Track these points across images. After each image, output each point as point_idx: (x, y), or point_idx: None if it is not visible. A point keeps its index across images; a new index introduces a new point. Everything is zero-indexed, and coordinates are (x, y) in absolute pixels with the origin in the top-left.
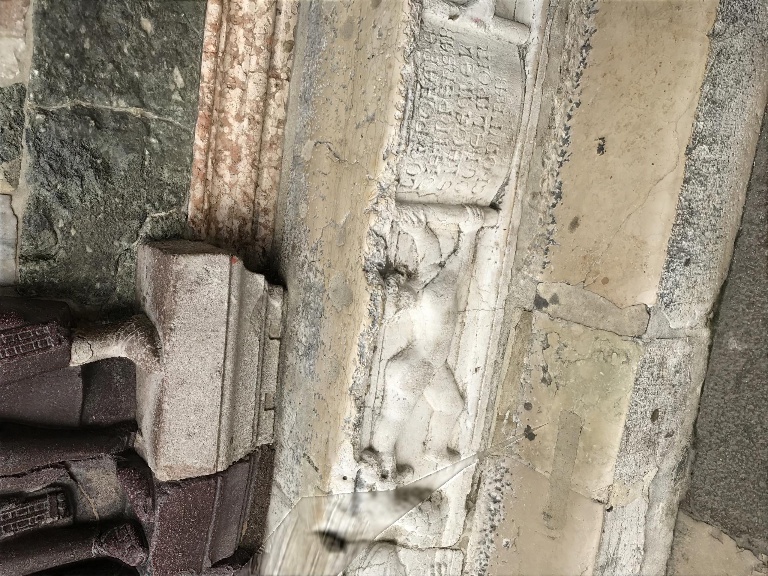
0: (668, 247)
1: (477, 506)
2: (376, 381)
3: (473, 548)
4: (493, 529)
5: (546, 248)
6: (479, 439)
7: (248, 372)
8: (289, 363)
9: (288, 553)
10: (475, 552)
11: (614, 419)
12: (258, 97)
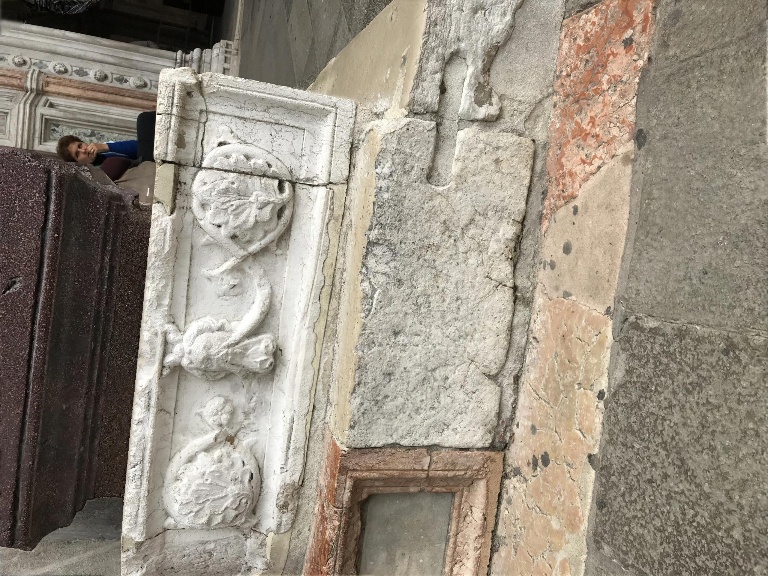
0: None
1: None
2: None
3: None
4: None
5: None
6: None
7: None
8: None
9: (80, 1)
10: None
11: None
12: None
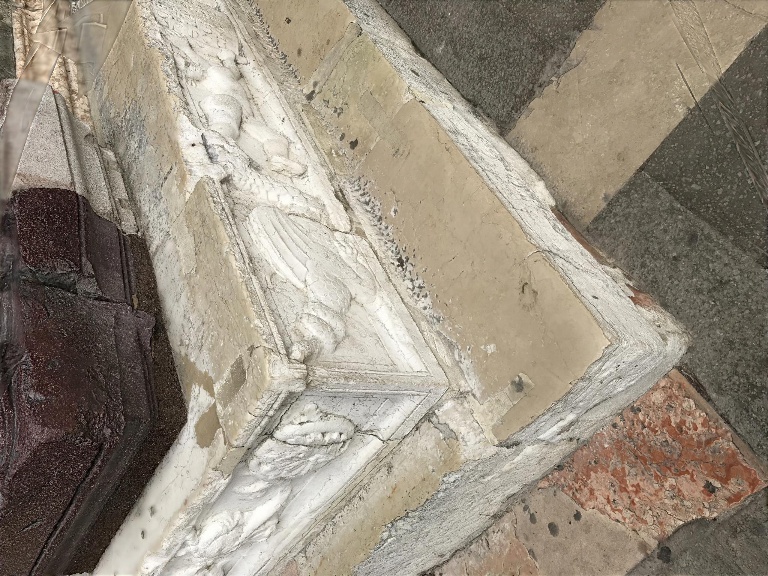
0: (342, 1)
1: (352, 207)
2: (194, 106)
3: (373, 238)
4: (380, 220)
5: (294, 76)
6: (315, 156)
7: (92, 166)
8: (133, 178)
9: None
10: (379, 242)
11: (379, 64)
12: (64, 96)
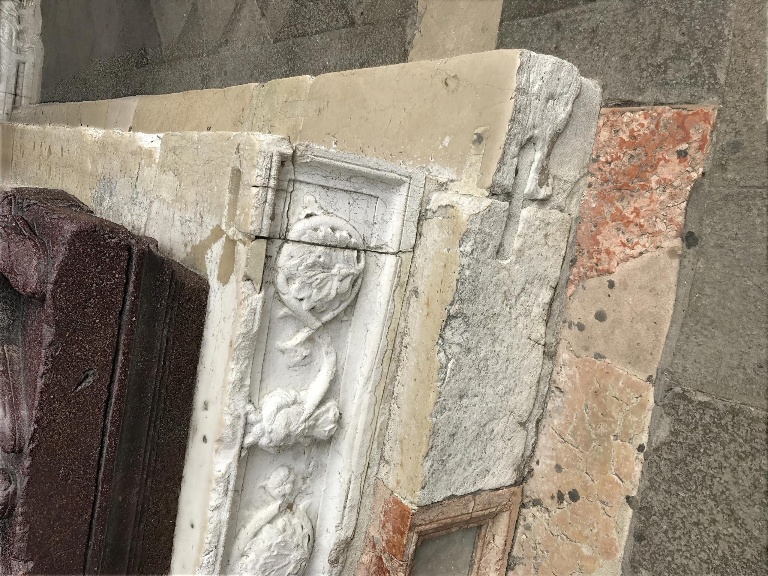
0: None
1: None
2: None
3: None
4: None
5: None
6: None
7: None
8: None
9: None
10: None
11: (283, 83)
12: None
